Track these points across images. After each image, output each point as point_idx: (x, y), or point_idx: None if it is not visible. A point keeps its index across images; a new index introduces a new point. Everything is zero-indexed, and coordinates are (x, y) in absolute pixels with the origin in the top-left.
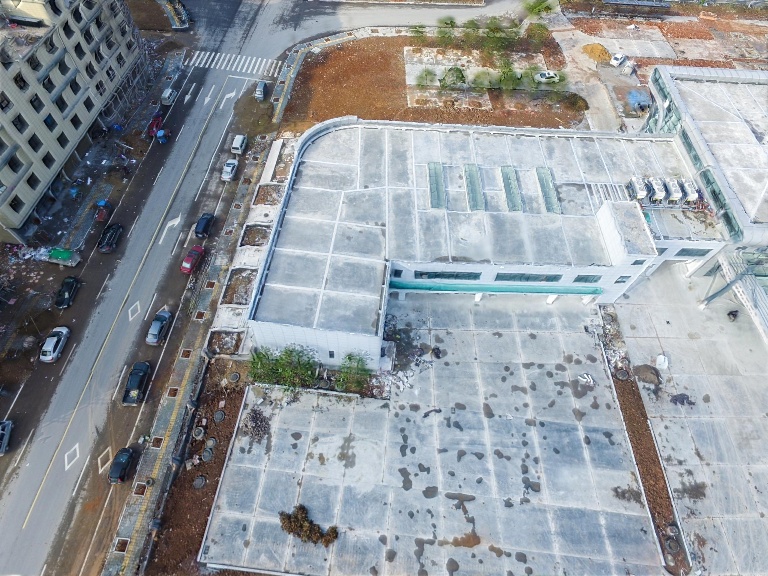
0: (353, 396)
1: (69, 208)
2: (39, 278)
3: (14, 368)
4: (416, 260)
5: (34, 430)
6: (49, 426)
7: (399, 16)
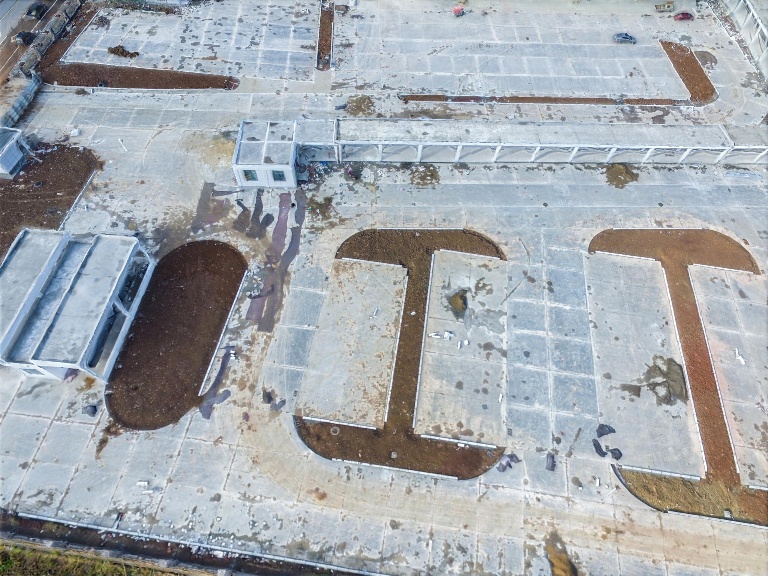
0: (161, 13)
1: None
2: None
3: None
4: None
5: None
6: None
7: None
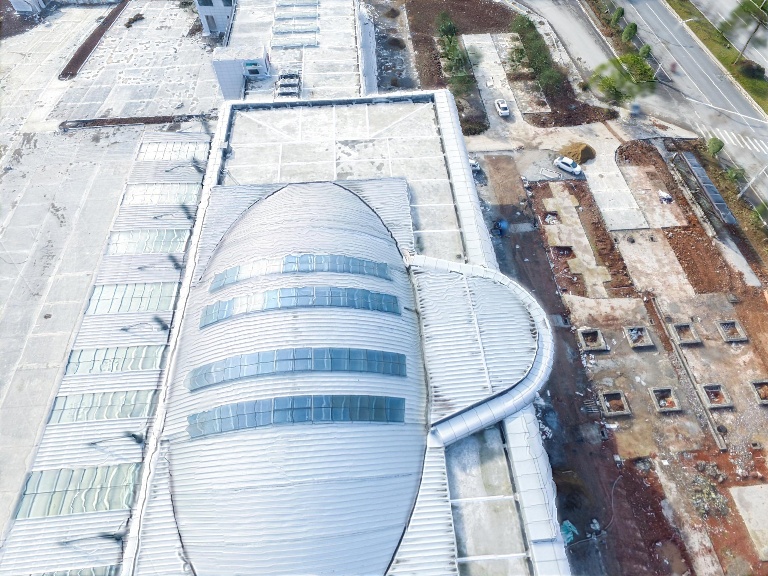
0: None
1: None
2: None
3: None
4: None
5: None
6: None
7: (575, 33)
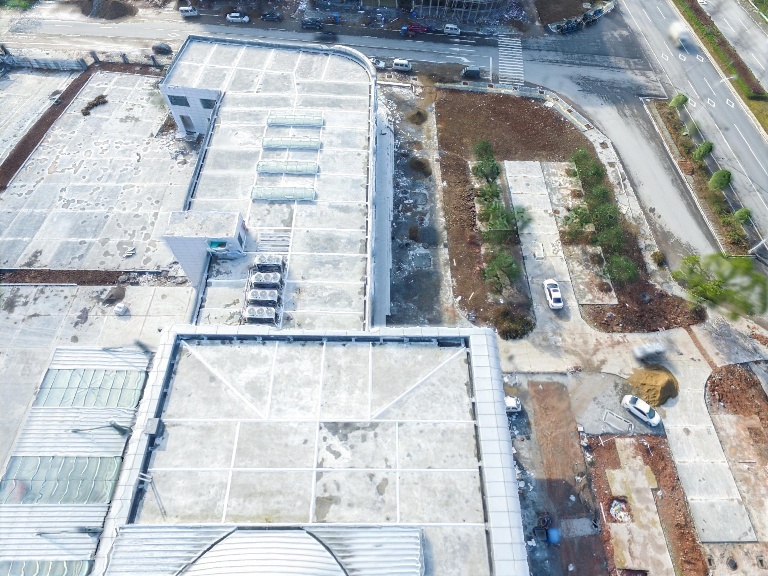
0: None
1: (338, 9)
2: (285, 8)
3: (226, 9)
4: (221, 107)
5: (192, 23)
6: (192, 26)
7: (647, 166)
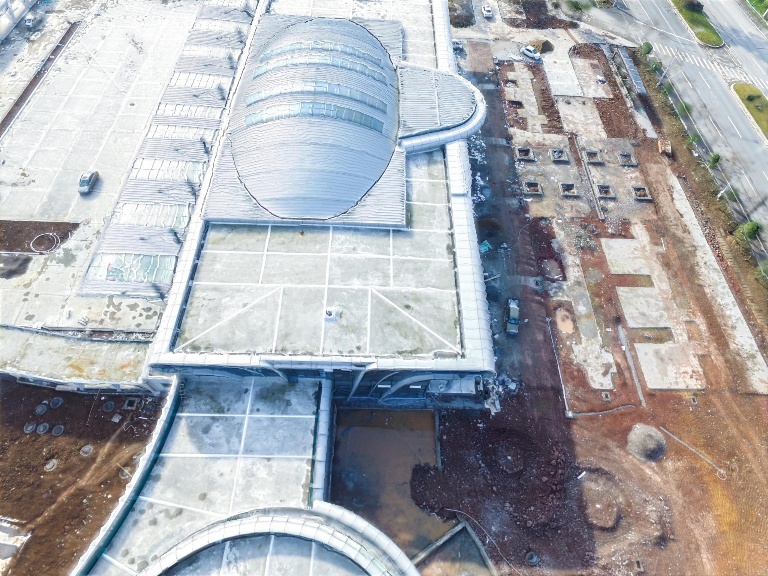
0: None
1: None
2: None
3: None
4: None
5: None
6: None
7: None
